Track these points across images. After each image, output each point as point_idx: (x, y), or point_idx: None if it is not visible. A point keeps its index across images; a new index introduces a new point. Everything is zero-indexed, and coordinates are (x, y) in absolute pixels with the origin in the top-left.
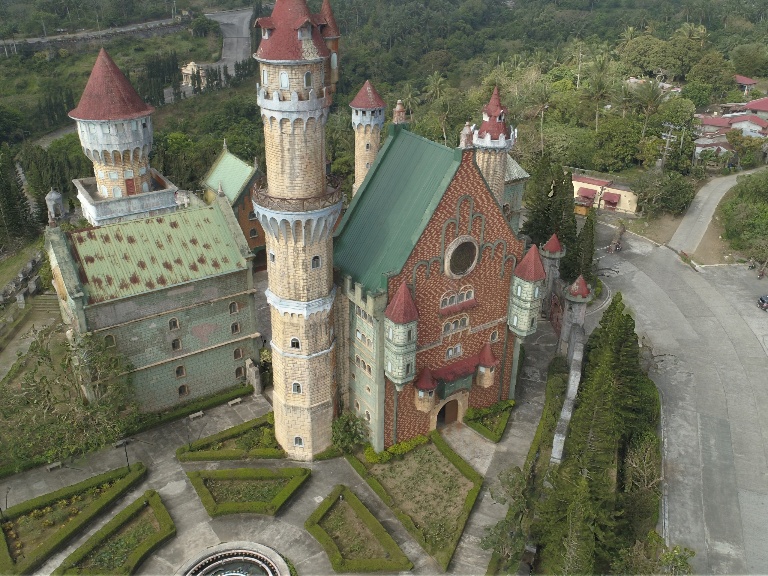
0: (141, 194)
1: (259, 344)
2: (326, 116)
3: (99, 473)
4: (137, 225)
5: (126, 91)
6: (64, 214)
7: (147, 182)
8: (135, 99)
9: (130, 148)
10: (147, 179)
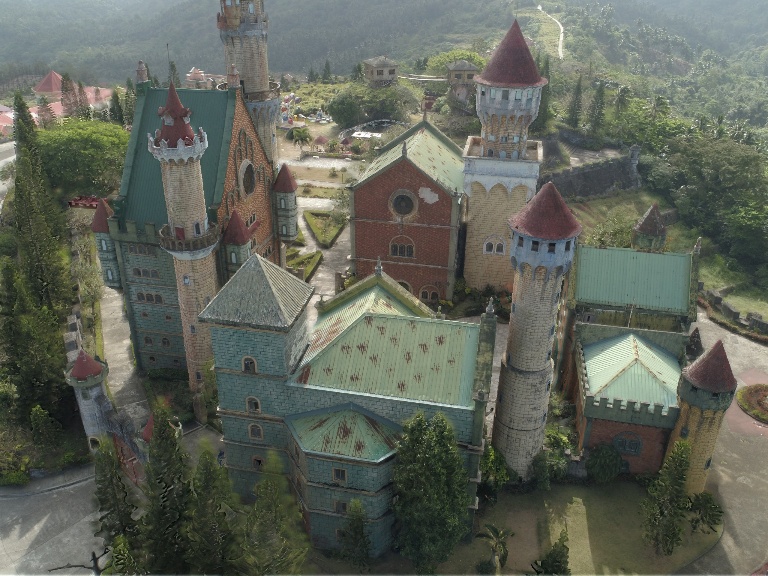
0: (467, 147)
1: None
2: (227, 39)
3: (345, 240)
4: None
5: None
6: None
7: None
8: None
9: None
10: None
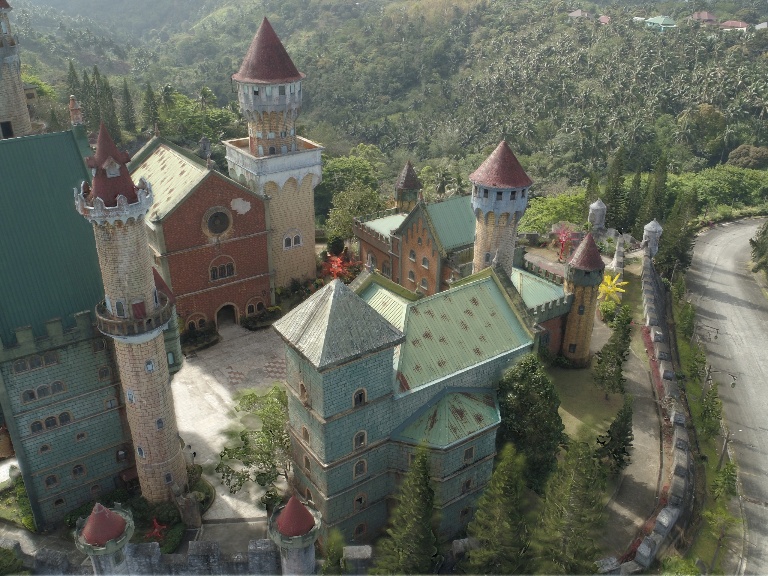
0: (242, 151)
1: (245, 339)
2: None
3: None
4: (176, 160)
5: (256, 58)
6: (598, 228)
7: (264, 146)
8: (260, 67)
9: (244, 108)
10: (264, 144)
